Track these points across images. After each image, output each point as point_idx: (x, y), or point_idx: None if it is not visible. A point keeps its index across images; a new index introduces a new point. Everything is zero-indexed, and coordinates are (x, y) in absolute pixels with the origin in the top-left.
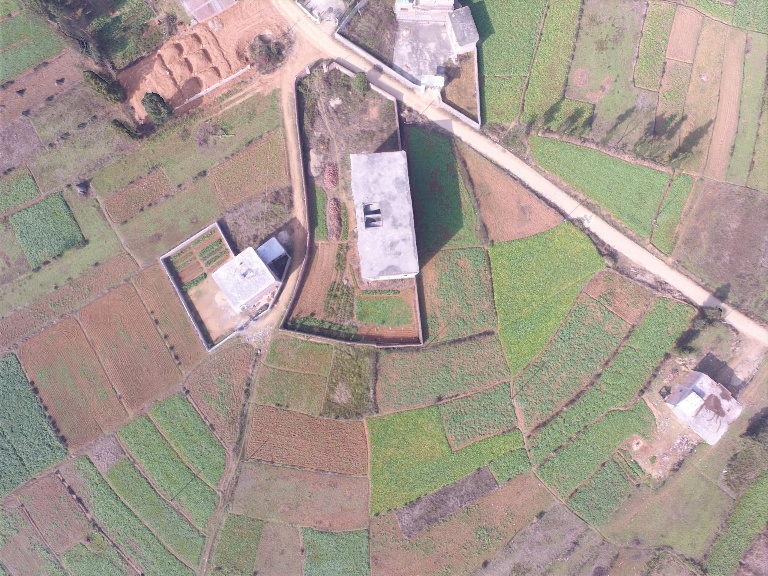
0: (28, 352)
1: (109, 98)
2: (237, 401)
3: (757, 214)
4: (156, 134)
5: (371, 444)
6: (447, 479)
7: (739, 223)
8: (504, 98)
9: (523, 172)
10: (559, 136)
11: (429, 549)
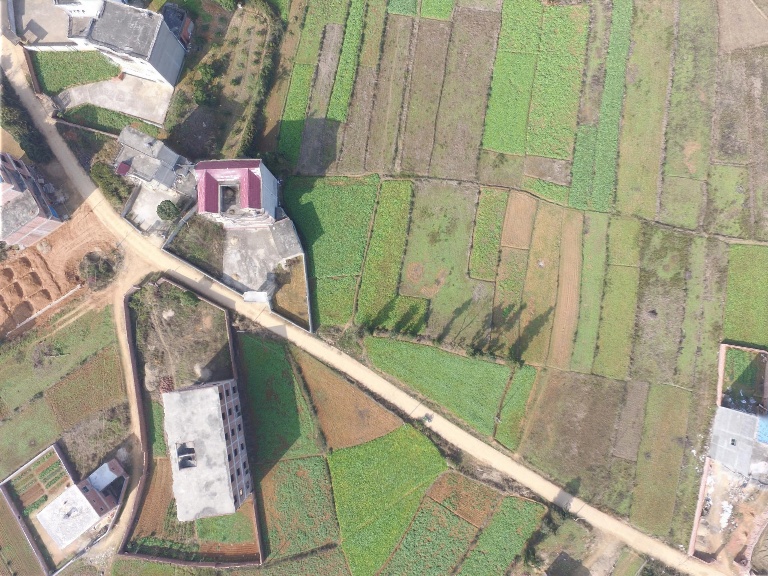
0: None
1: None
2: None
3: (605, 402)
4: None
5: None
6: None
7: (586, 413)
8: (337, 300)
9: (360, 374)
10: (394, 336)
11: None
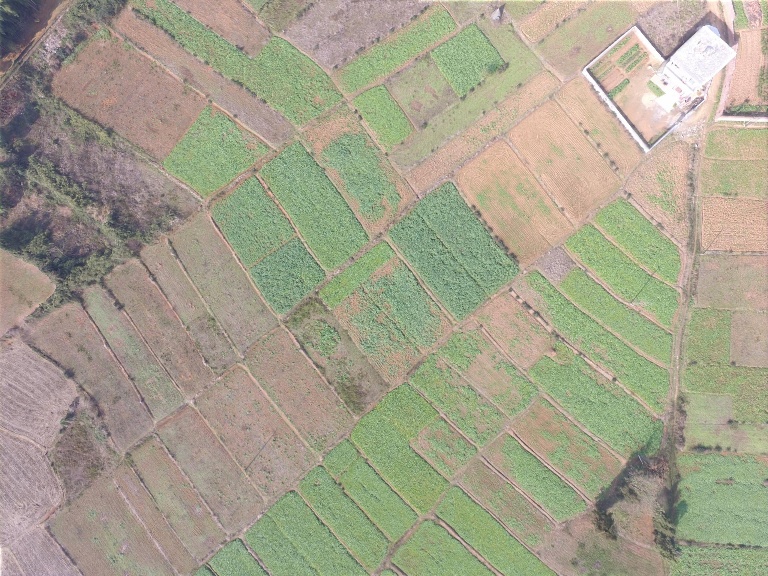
0: (465, 178)
1: None
2: (681, 197)
3: None
4: None
5: None
6: None
7: None
8: None
9: None
10: None
11: None
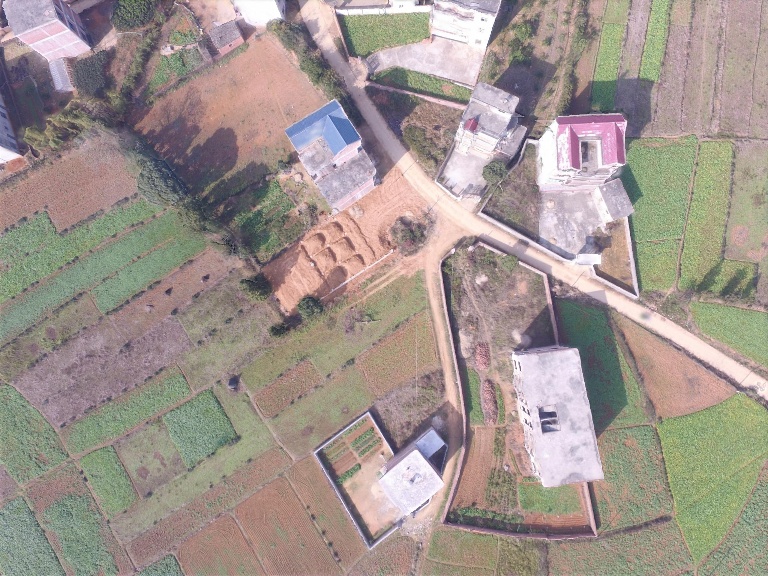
0: (187, 553)
1: (259, 299)
2: None
3: None
4: (303, 325)
5: None
6: None
7: None
8: (659, 264)
9: (686, 341)
10: (723, 301)
11: None
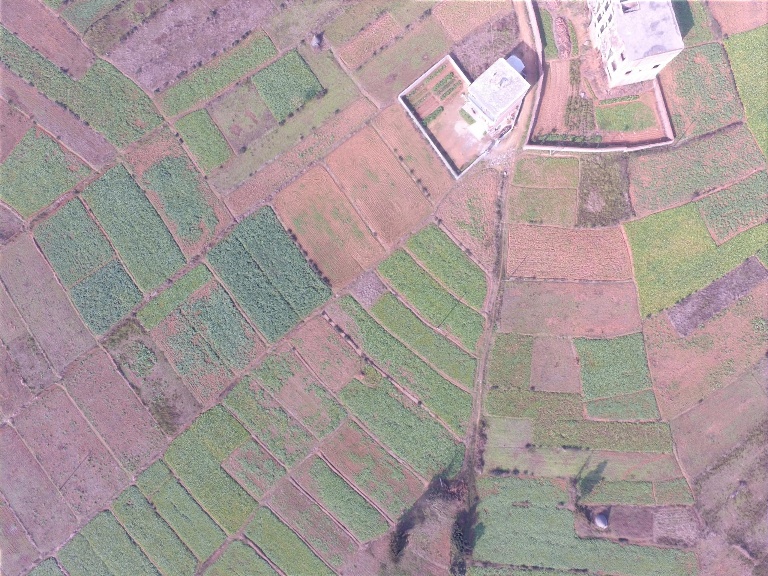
0: (282, 202)
1: None
2: (490, 224)
3: None
4: None
5: (632, 248)
6: (716, 273)
7: None
8: None
9: None
10: None
11: (708, 345)
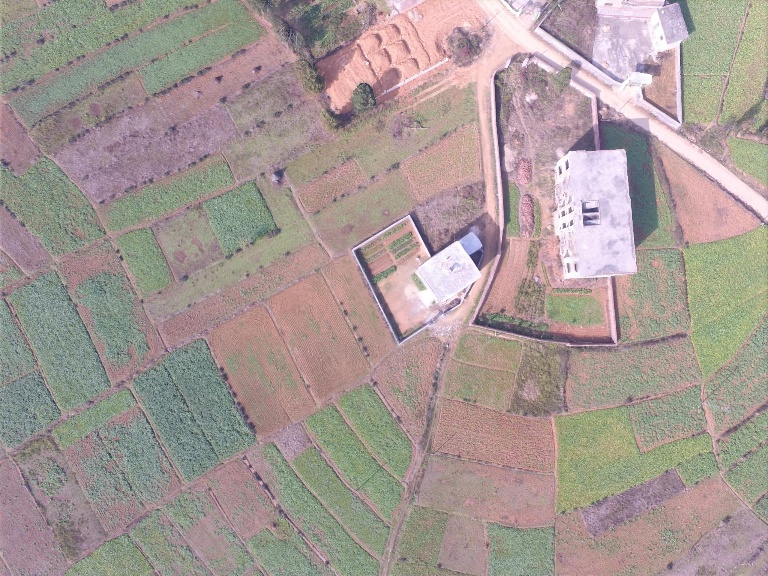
0: (218, 338)
1: (313, 87)
2: (424, 394)
3: None
4: (352, 125)
5: (559, 442)
6: (635, 480)
7: None
8: (703, 98)
9: (719, 174)
10: (759, 138)
11: (614, 549)
